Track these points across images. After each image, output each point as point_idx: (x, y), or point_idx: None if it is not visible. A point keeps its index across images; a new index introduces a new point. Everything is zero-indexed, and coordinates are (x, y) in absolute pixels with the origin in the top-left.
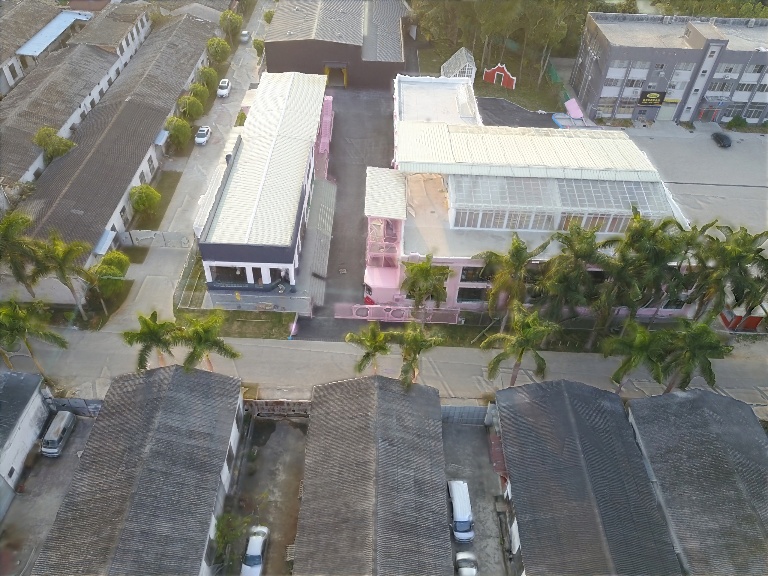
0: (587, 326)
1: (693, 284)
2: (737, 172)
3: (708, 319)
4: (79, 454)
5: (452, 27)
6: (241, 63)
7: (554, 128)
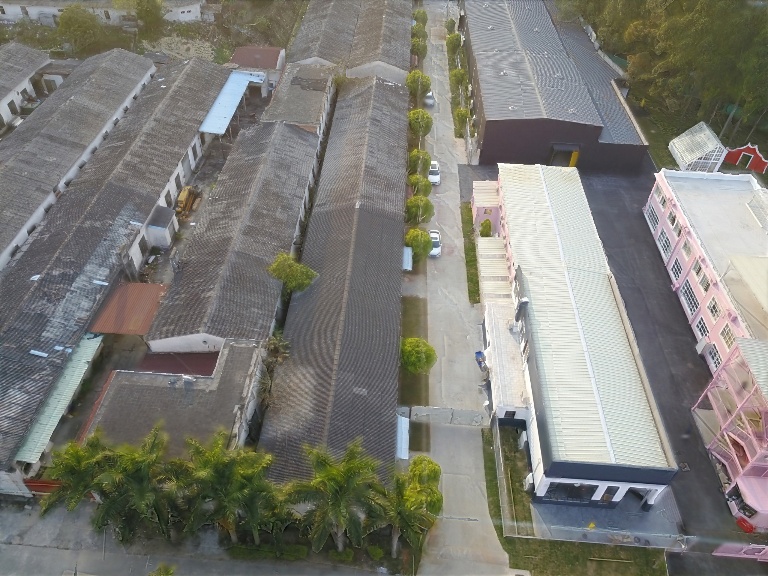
0: None
1: None
2: None
3: None
4: None
5: (688, 97)
6: (436, 135)
7: None
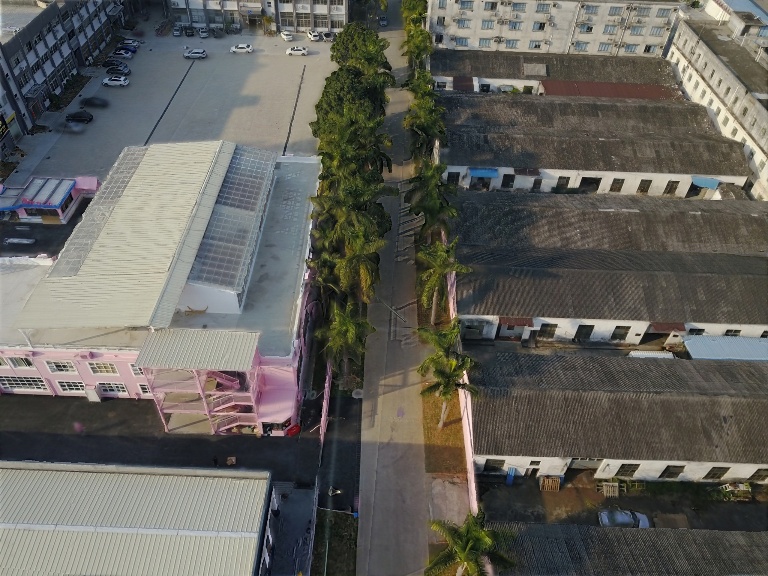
0: None
1: (368, 166)
2: (131, 127)
3: (424, 164)
4: None
5: None
6: None
7: None
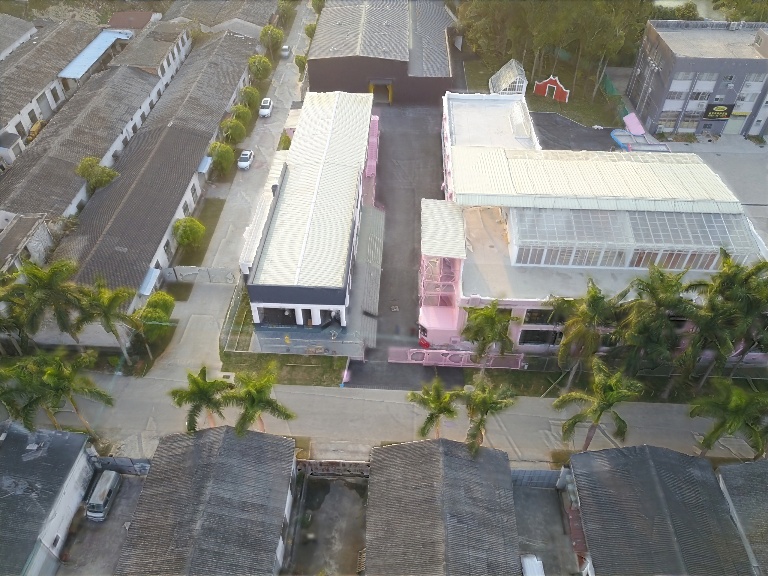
0: (662, 372)
1: None
2: None
3: None
4: (126, 526)
5: (501, 38)
6: (282, 80)
7: (613, 145)
